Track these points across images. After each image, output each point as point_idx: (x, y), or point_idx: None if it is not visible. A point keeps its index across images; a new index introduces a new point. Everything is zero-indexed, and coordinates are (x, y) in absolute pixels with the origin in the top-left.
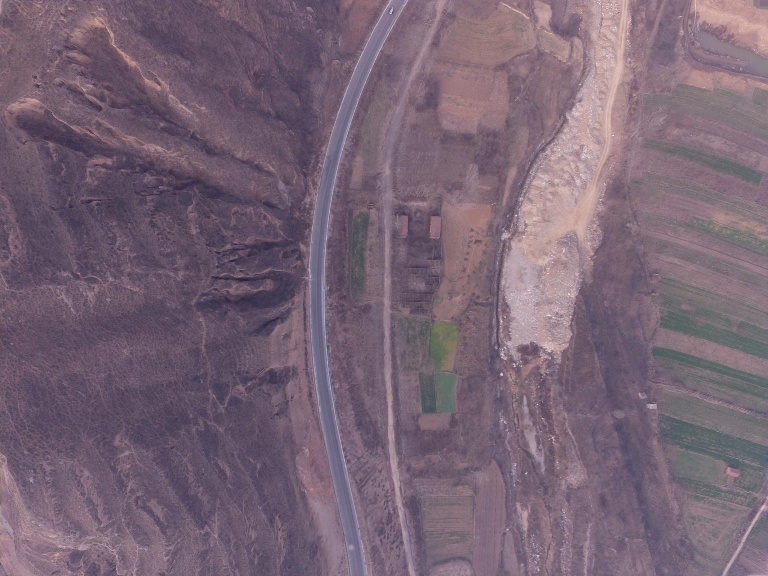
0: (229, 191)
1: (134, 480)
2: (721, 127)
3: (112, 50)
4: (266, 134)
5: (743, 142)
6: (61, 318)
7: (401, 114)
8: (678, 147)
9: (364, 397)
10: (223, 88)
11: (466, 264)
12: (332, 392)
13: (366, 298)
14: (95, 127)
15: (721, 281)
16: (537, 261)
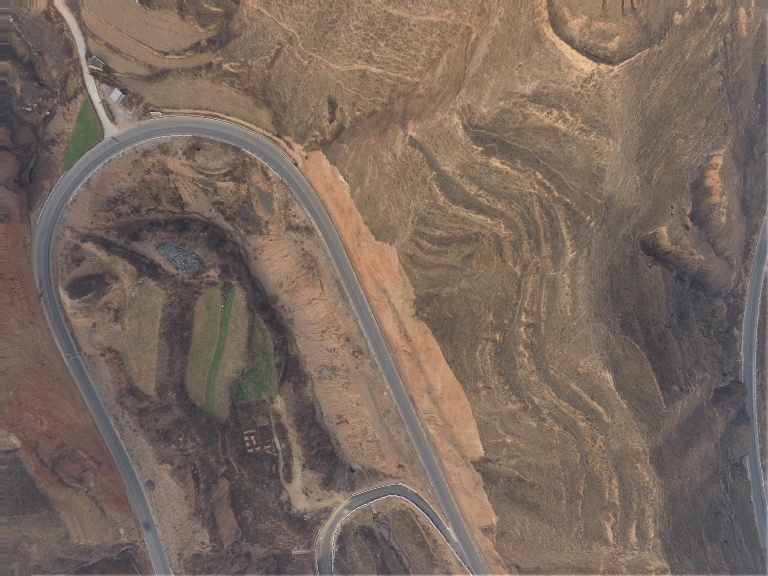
0: (709, 286)
1: None
2: None
3: (698, 172)
4: (743, 232)
5: None
6: None
7: None
8: None
9: None
10: None
11: None
12: (762, 469)
13: None
14: None
15: None
16: None
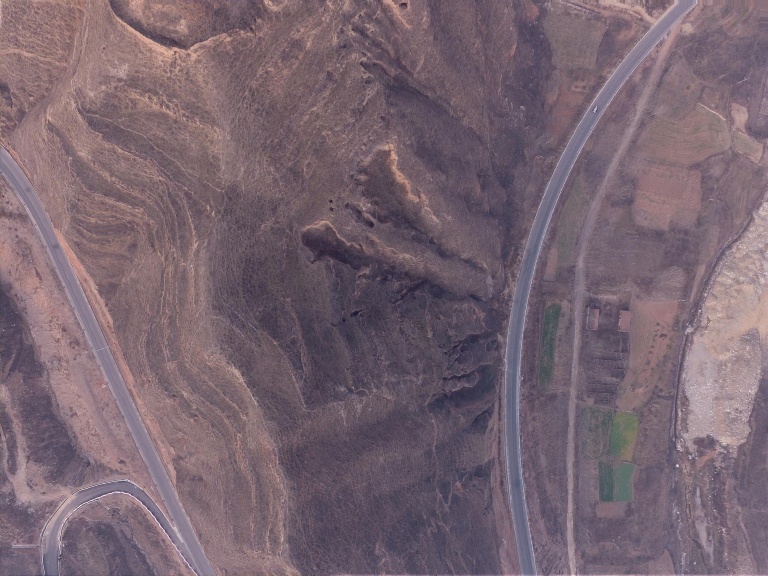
0: (449, 289)
1: None
2: None
3: (385, 168)
4: (487, 234)
5: None
6: (336, 431)
7: (597, 209)
8: None
9: (546, 484)
10: (462, 195)
11: (650, 357)
12: (523, 481)
13: (553, 387)
14: (364, 241)
15: None
16: (718, 356)
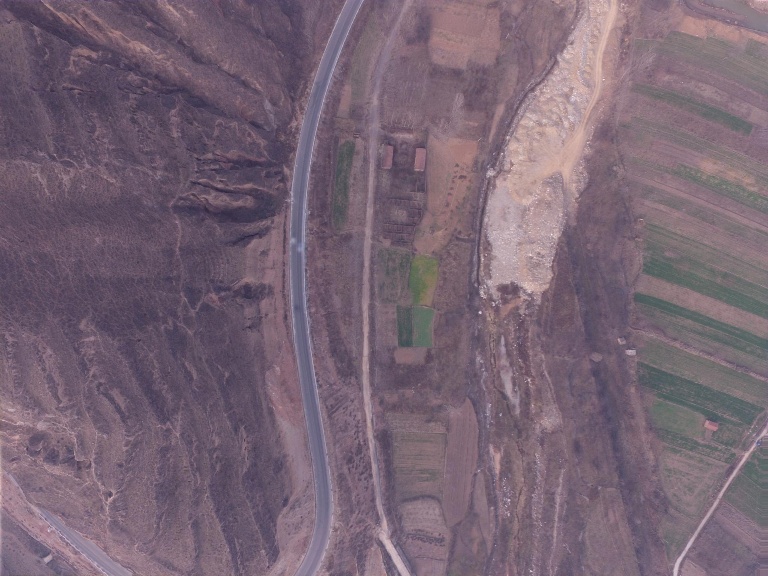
0: (214, 104)
1: (98, 367)
2: (713, 76)
3: None
4: (254, 49)
5: (734, 92)
6: (35, 197)
7: (392, 46)
8: (668, 93)
9: (340, 326)
10: None
11: (449, 199)
12: (307, 316)
13: (347, 227)
14: (81, 17)
15: (707, 230)
16: (521, 200)
